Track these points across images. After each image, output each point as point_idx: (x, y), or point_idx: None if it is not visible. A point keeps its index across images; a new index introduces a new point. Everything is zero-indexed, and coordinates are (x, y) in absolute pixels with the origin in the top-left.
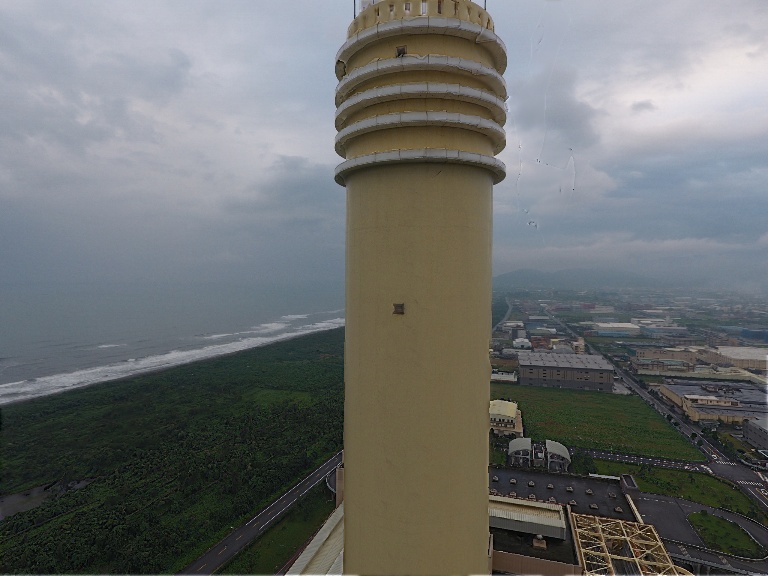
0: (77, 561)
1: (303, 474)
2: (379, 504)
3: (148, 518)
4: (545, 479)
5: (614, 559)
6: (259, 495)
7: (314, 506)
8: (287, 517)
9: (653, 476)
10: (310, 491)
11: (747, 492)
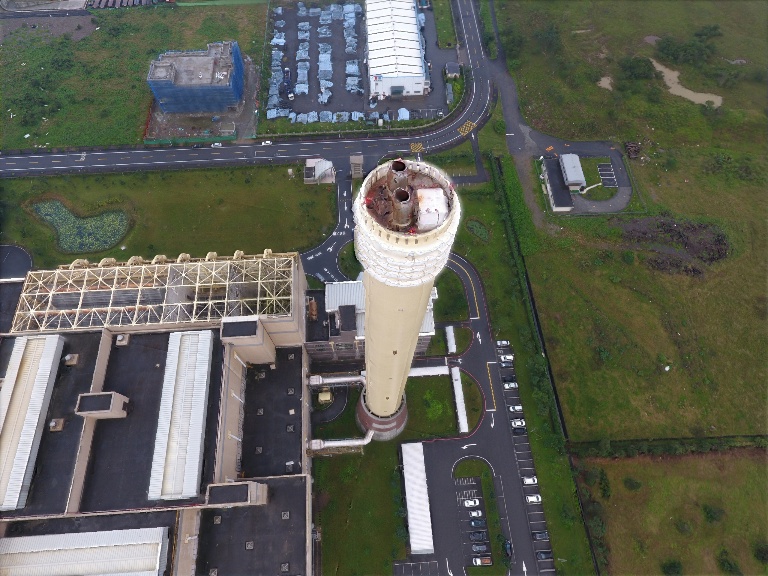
0: None
1: None
2: None
3: None
4: None
5: None
6: None
7: None
8: None
9: None
10: None
11: None
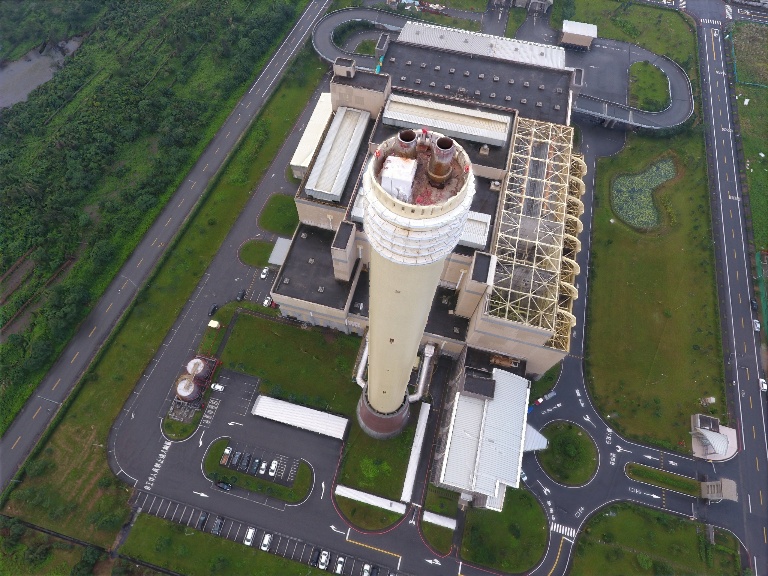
0: (128, 136)
1: (287, 28)
2: (386, 322)
3: (163, 92)
4: (510, 71)
5: (536, 151)
6: (252, 59)
7: (306, 73)
8: (283, 83)
9: (624, 19)
10: (299, 54)
11: (701, 34)
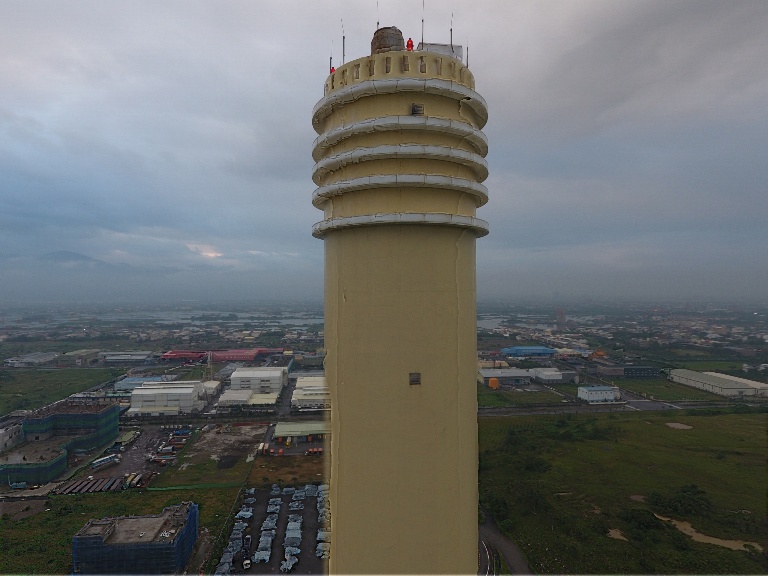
0: None
1: None
2: None
3: None
4: None
5: None
6: None
7: None
8: None
9: None
10: None
11: None
